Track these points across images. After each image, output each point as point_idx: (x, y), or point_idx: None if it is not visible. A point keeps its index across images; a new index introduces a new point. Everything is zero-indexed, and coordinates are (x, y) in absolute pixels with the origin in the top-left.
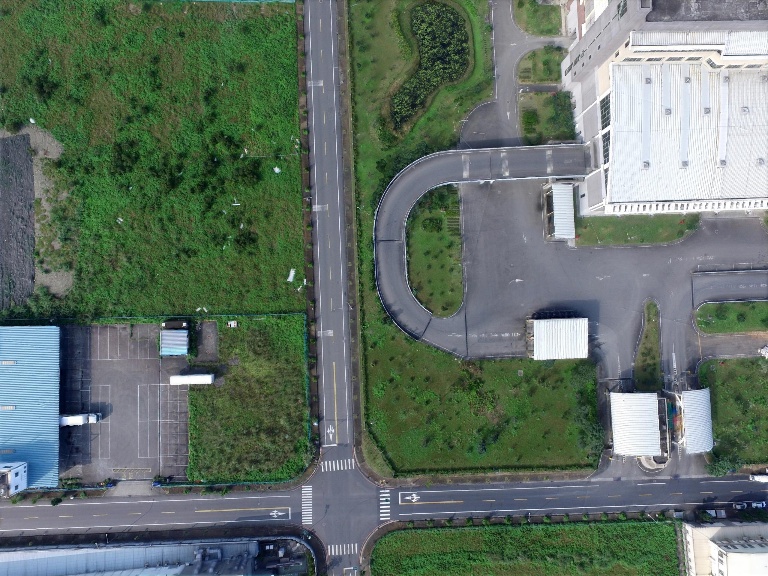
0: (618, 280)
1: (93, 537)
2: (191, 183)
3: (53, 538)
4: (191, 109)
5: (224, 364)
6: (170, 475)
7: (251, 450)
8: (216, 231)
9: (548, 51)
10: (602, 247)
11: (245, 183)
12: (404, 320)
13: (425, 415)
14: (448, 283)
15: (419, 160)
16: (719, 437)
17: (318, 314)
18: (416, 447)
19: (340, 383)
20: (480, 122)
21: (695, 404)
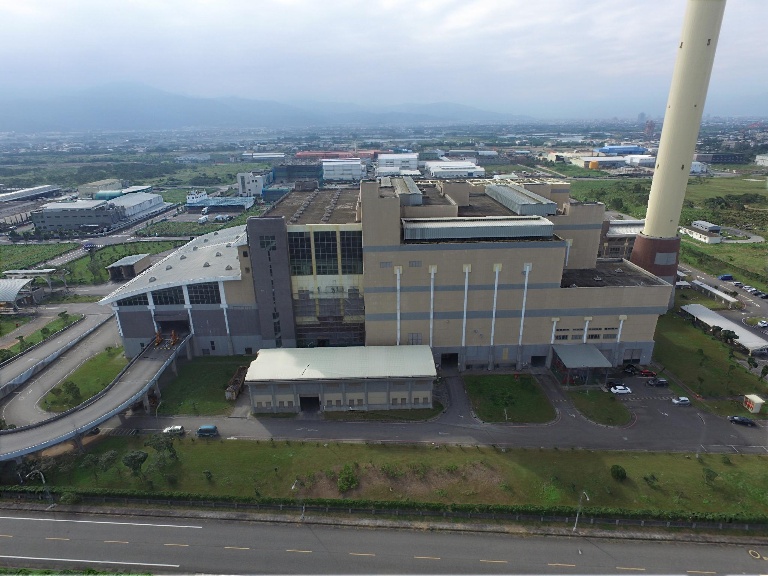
0: None
1: (158, 215)
2: None
3: (165, 212)
4: None
5: None
6: None
7: None
8: None
9: None
10: None
11: None
12: None
13: None
14: None
15: None
16: None
17: None
18: None
19: None
20: None
21: (16, 283)
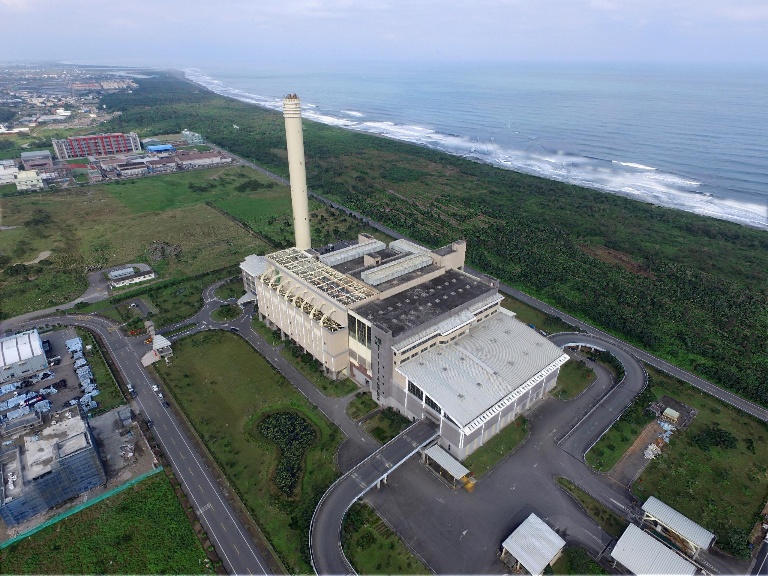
0: (524, 481)
1: None
2: None
3: None
4: None
5: None
6: None
7: None
8: None
9: (359, 396)
10: (493, 469)
11: None
12: None
13: None
14: None
15: (322, 500)
16: (711, 531)
17: None
18: None
19: None
20: (348, 455)
21: (659, 510)
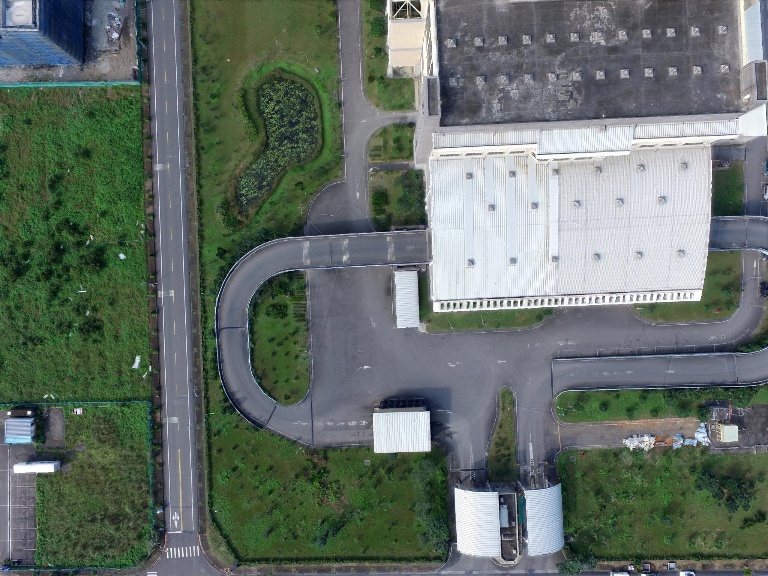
0: (471, 367)
1: None
2: (37, 271)
3: None
4: (38, 196)
5: (71, 451)
6: (19, 559)
7: (97, 536)
8: (62, 318)
9: (396, 129)
10: (455, 332)
11: (89, 271)
12: (248, 408)
13: (269, 504)
14: (293, 370)
15: (259, 247)
16: (578, 531)
17: (163, 401)
18: (260, 536)
19: (185, 470)
20: (328, 203)
21: (539, 504)
